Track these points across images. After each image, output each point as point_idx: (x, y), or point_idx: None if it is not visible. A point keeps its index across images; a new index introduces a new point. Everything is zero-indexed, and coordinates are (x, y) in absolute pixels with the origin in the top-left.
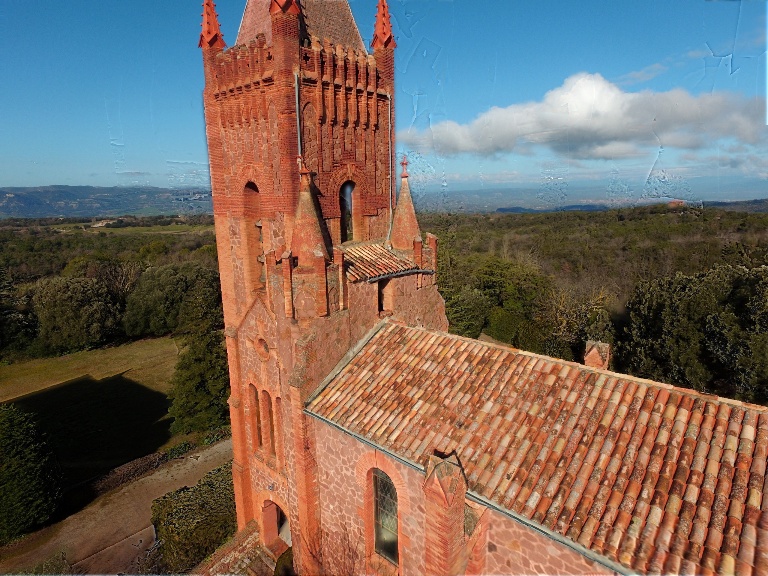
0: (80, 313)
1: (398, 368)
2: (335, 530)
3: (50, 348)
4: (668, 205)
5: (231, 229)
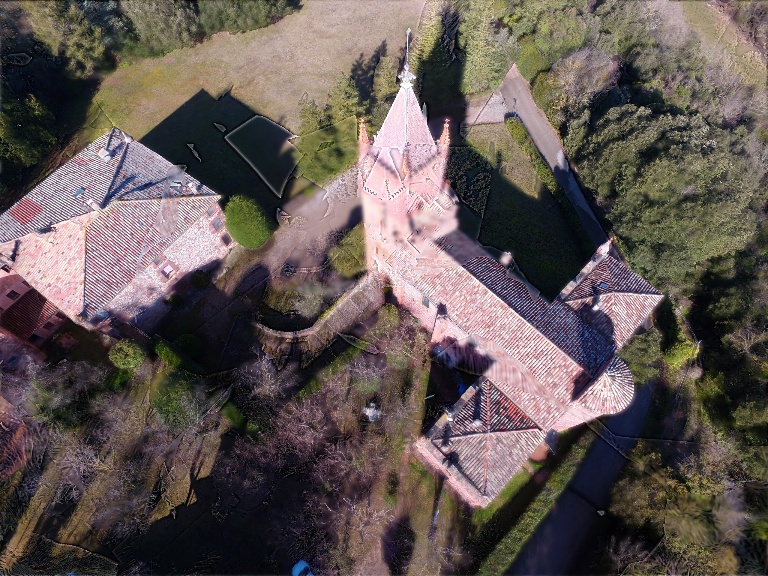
0: (169, 23)
1: None
2: (409, 295)
3: (154, 50)
4: None
5: None
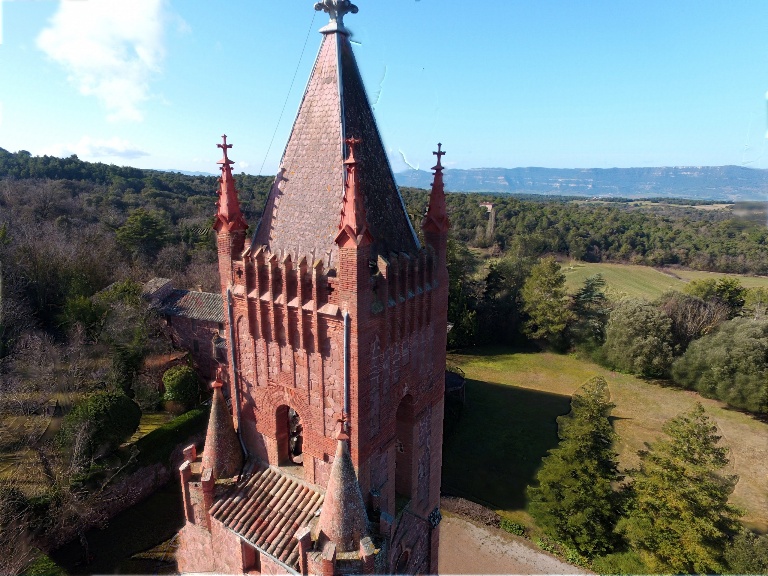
0: (633, 341)
1: None
2: None
3: (606, 360)
4: None
5: None
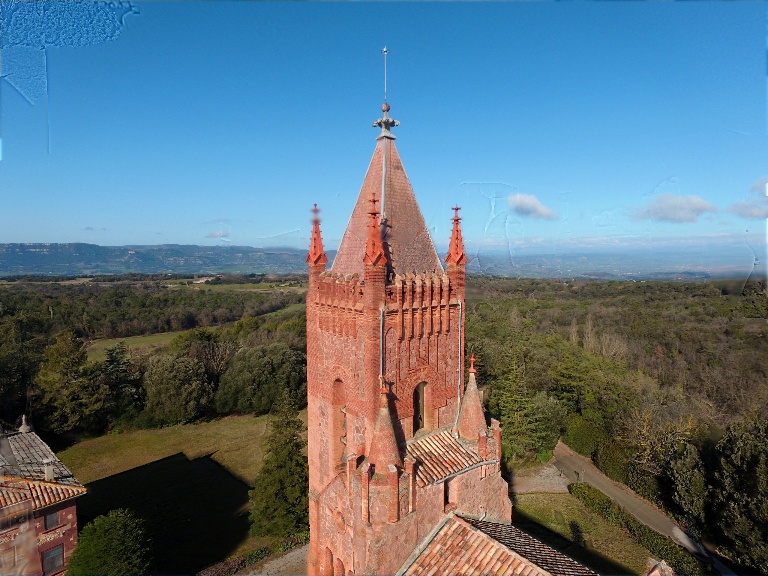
0: (181, 391)
1: None
2: None
3: (153, 421)
4: (766, 326)
5: (321, 409)
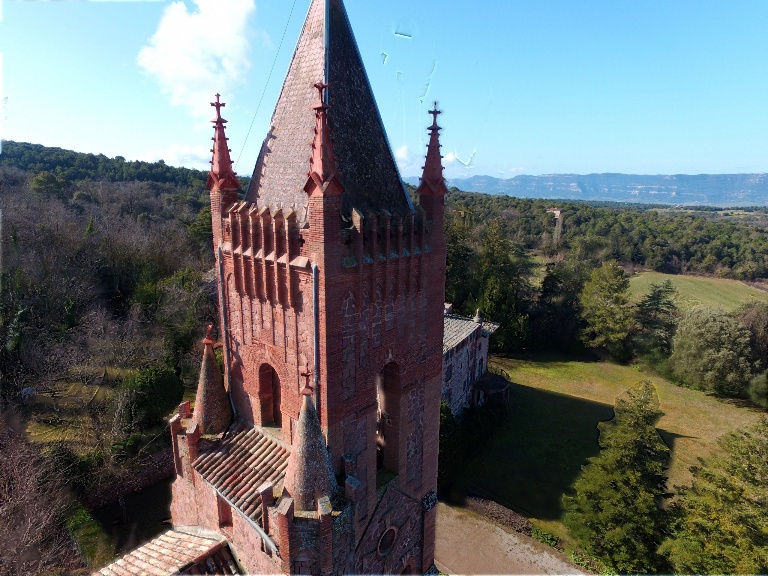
0: (704, 354)
1: (135, 574)
2: None
3: (672, 374)
4: None
5: None
